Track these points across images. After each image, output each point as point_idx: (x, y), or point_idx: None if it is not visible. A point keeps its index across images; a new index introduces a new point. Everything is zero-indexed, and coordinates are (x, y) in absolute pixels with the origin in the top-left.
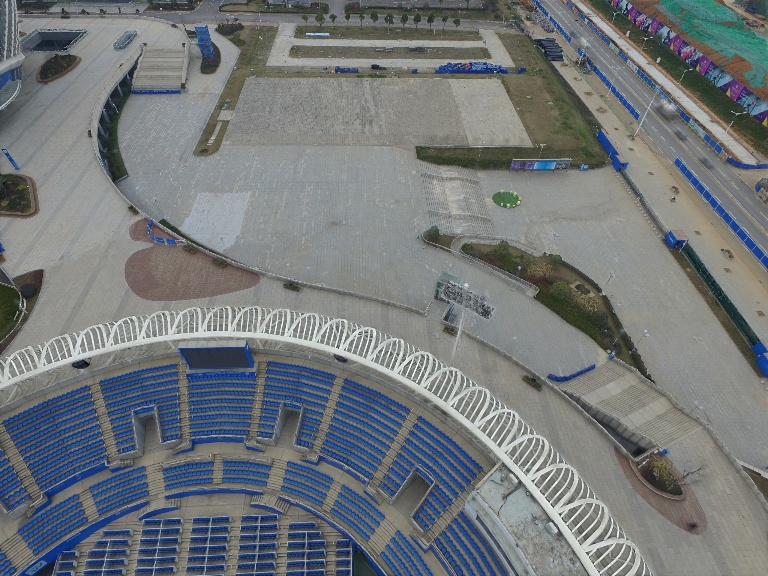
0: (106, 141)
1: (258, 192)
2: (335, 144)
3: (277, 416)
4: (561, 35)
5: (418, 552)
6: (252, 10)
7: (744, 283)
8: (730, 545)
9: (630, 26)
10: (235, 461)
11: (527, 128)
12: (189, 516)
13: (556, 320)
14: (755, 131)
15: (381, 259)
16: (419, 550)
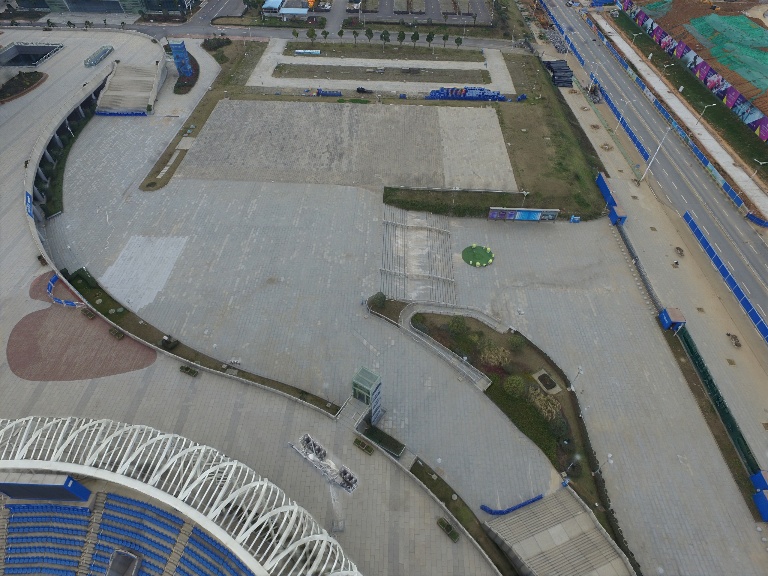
0: (48, 171)
1: (196, 237)
2: (295, 181)
3: (107, 568)
4: (575, 56)
5: None
6: (245, 23)
7: (751, 382)
8: None
9: (654, 48)
10: None
11: (515, 169)
12: None
13: (505, 425)
14: None
15: (314, 330)
16: None
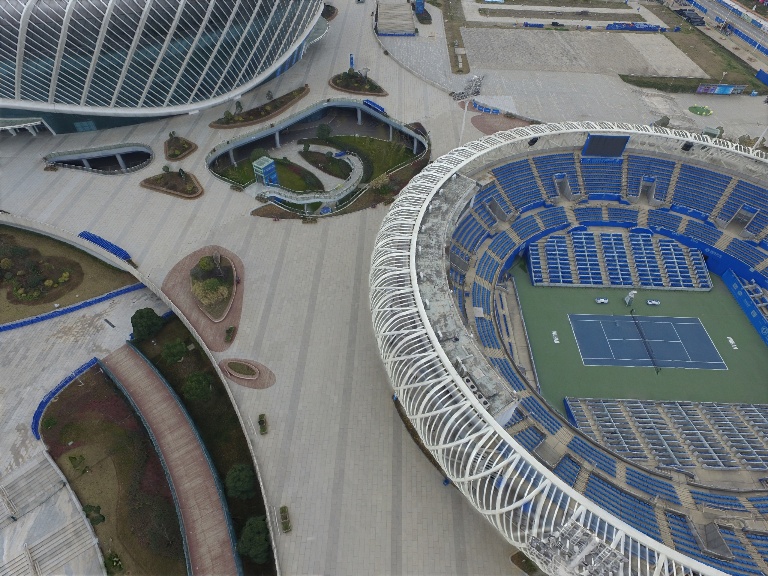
0: None
1: (517, 96)
2: (556, 71)
3: (640, 184)
4: (695, 8)
5: (752, 246)
6: None
7: None
8: None
9: (754, 3)
10: (616, 208)
11: (701, 66)
12: (595, 234)
13: None
14: None
15: None
16: (752, 246)
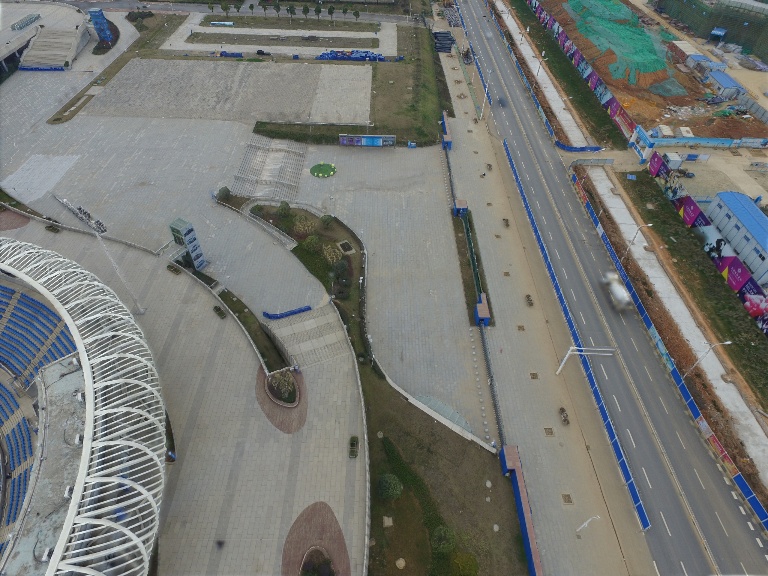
0: None
1: (87, 155)
2: (182, 117)
3: None
4: None
5: (30, 433)
6: (170, 0)
7: (507, 248)
8: (312, 443)
9: (535, 23)
10: None
11: (372, 109)
12: None
13: (300, 270)
14: (599, 118)
15: (169, 214)
16: (32, 432)
